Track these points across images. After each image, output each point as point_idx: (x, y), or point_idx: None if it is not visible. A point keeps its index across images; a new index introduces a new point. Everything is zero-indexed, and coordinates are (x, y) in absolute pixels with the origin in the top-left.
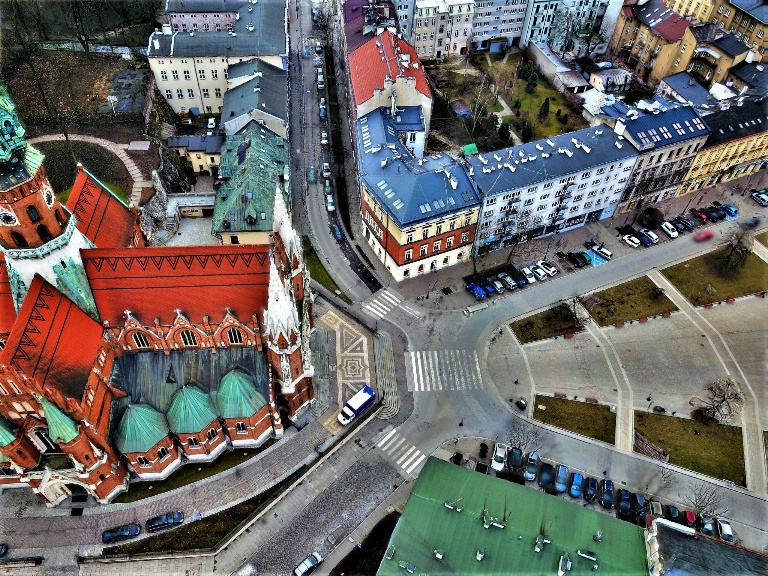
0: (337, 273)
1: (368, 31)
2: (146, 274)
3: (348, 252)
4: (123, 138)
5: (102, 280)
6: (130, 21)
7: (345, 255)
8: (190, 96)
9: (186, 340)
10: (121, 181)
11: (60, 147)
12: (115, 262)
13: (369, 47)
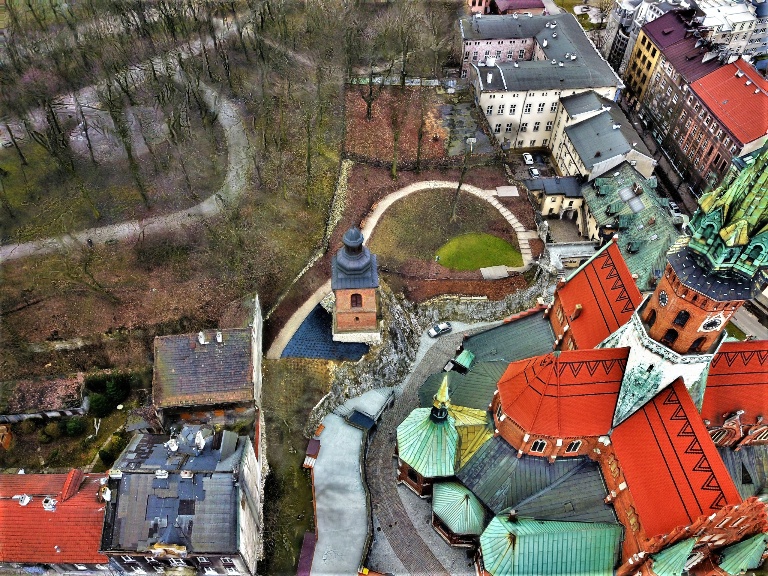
0: (751, 330)
1: (709, 58)
2: (761, 369)
3: (748, 305)
4: (488, 183)
5: (714, 377)
6: (401, 47)
7: (747, 309)
8: (506, 130)
9: (759, 435)
10: (501, 232)
11: (433, 196)
12: (733, 357)
13: (722, 77)
